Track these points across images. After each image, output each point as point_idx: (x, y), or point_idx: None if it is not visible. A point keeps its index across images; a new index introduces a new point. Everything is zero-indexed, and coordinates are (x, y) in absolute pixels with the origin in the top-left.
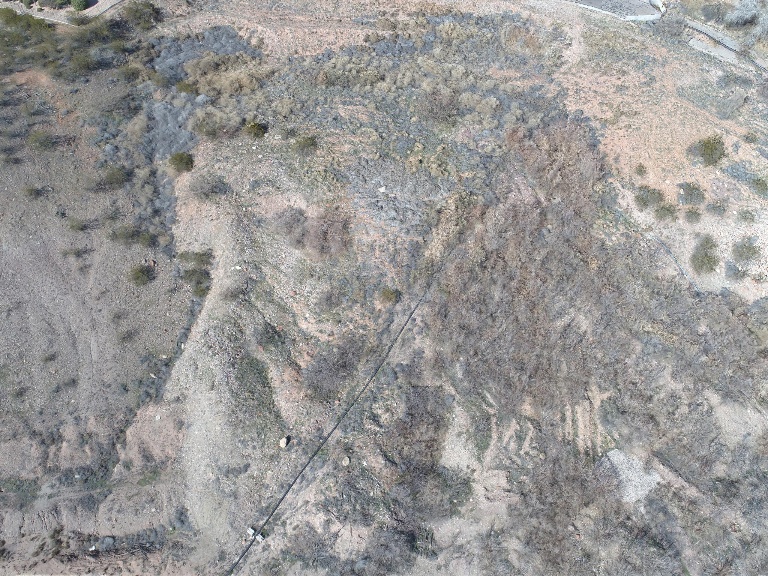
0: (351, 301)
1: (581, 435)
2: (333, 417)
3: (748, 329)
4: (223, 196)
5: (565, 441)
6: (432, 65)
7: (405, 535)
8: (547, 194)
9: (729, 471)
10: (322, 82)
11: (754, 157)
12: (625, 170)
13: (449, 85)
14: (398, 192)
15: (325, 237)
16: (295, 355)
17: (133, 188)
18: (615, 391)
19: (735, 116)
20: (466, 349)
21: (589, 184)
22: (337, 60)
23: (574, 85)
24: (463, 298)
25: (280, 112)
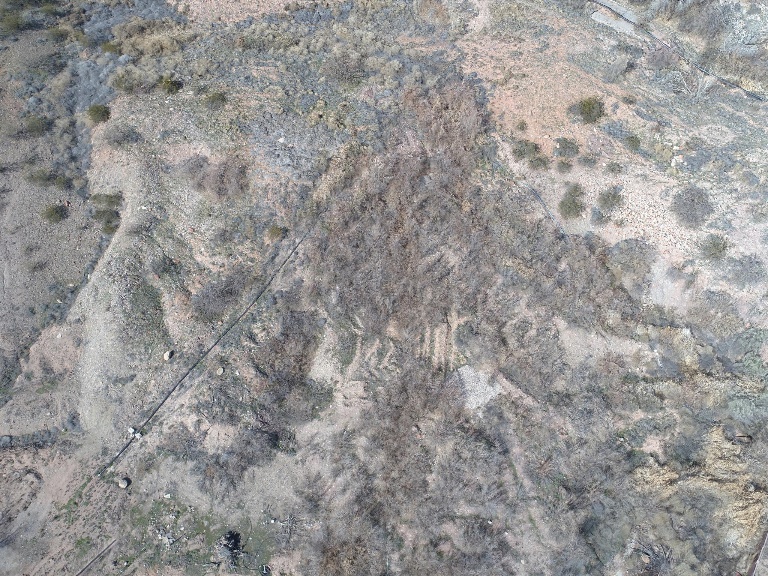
0: (242, 237)
1: (436, 353)
2: (215, 335)
3: (606, 268)
4: (134, 144)
5: (422, 358)
6: (345, 32)
7: (268, 434)
8: (433, 146)
9: (568, 386)
10: (239, 45)
11: (631, 117)
12: (508, 126)
13: (359, 50)
14: (296, 142)
15: (222, 180)
16: (188, 283)
17: (52, 136)
18: (473, 317)
19: (620, 80)
20: (341, 279)
21: (471, 137)
22: (256, 26)
23: (473, 51)
24: (344, 235)
25: (196, 71)
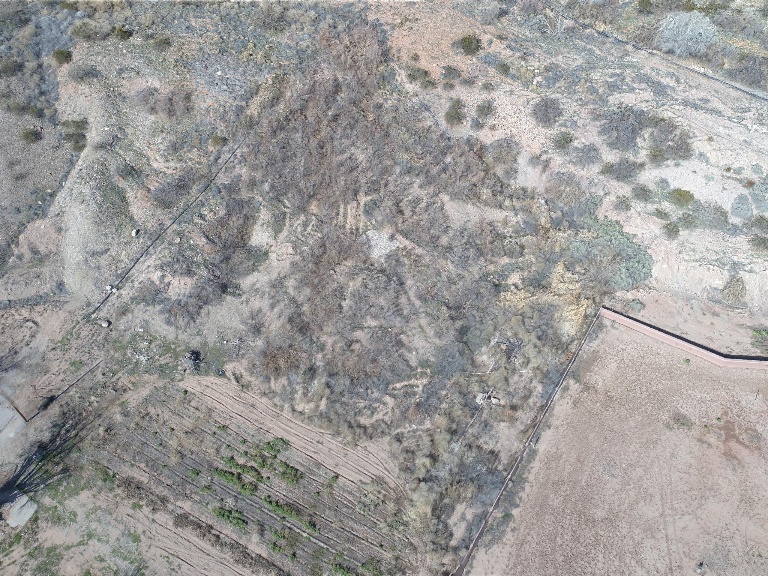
0: (190, 146)
1: (349, 222)
2: (172, 217)
3: (483, 161)
4: (95, 79)
5: None
6: None
7: (218, 283)
8: (343, 74)
9: (450, 241)
10: (180, 2)
11: (502, 49)
12: (404, 58)
13: (281, 5)
14: (231, 74)
15: (171, 102)
16: (147, 183)
17: (23, 76)
18: (377, 196)
19: (495, 23)
20: (272, 172)
21: (374, 66)
22: None
23: (376, 3)
24: None
25: (144, 23)
